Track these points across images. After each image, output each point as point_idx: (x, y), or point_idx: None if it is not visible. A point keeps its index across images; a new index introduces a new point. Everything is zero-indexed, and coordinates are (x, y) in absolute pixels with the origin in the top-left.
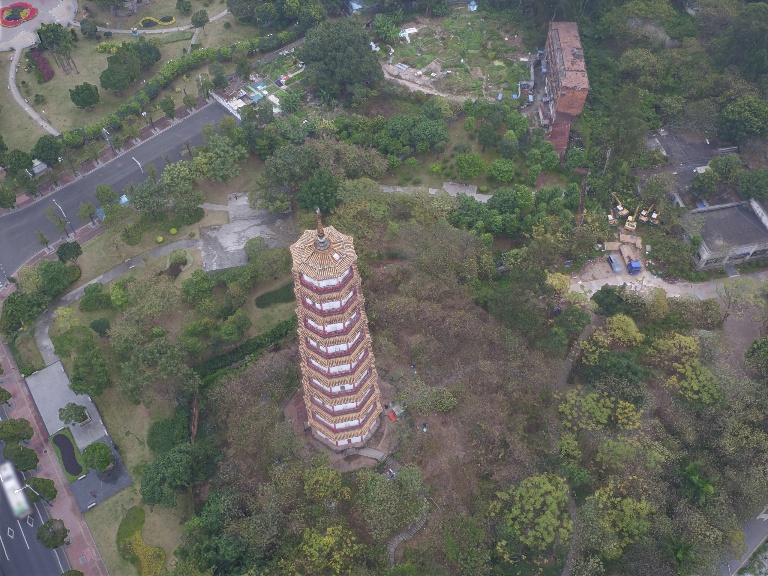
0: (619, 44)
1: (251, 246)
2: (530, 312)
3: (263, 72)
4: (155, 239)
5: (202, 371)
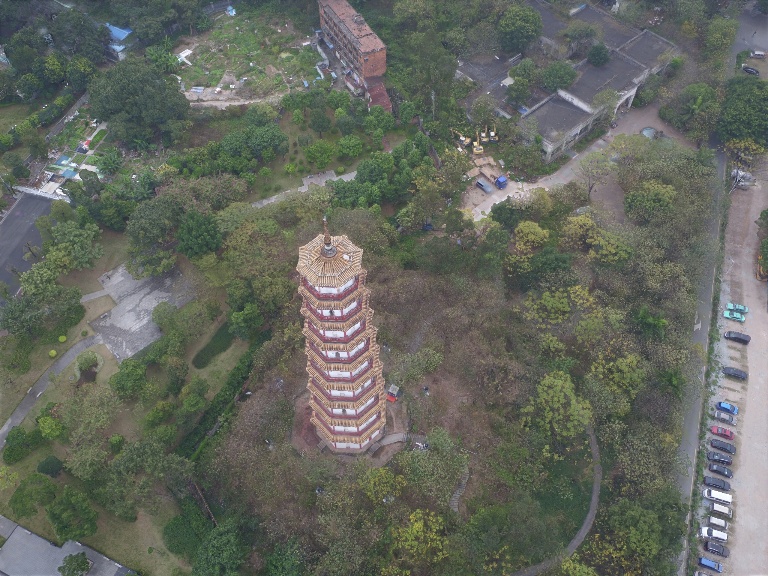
0: (383, 1)
1: (160, 314)
2: (461, 251)
3: (58, 146)
4: (47, 356)
5: (183, 454)
